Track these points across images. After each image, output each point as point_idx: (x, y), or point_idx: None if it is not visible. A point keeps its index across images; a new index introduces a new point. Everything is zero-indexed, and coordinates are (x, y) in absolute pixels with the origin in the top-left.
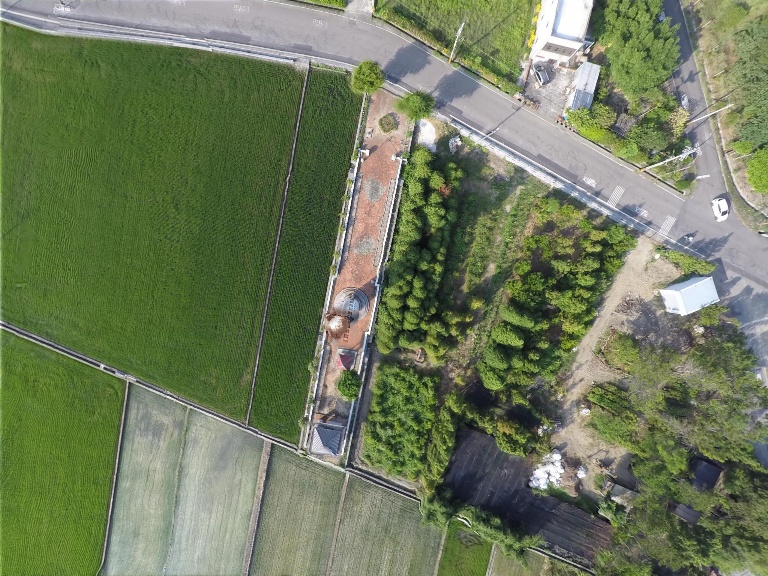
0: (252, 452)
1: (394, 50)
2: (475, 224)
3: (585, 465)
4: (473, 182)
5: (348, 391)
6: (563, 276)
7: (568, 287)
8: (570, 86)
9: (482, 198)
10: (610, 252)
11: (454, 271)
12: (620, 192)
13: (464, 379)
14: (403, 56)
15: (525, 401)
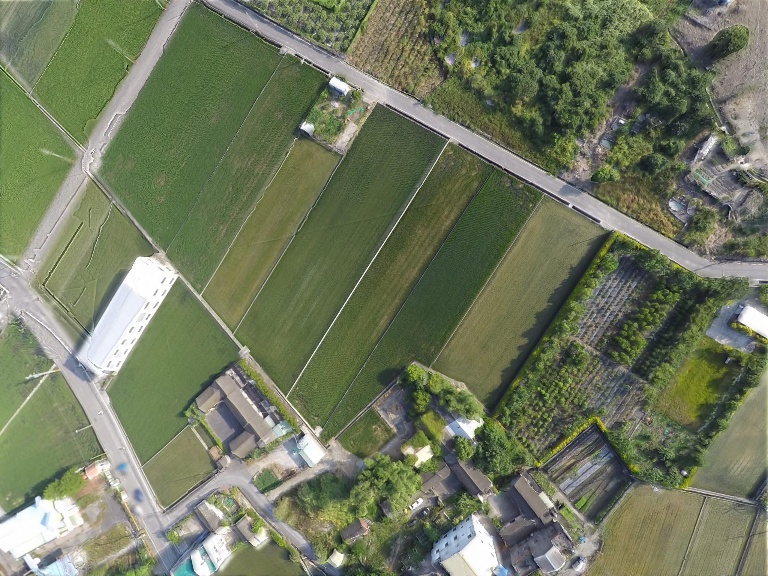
0: None
1: None
2: None
3: None
4: None
5: None
6: None
7: None
8: None
9: None
10: None
11: None
12: None
13: None
14: None
15: None
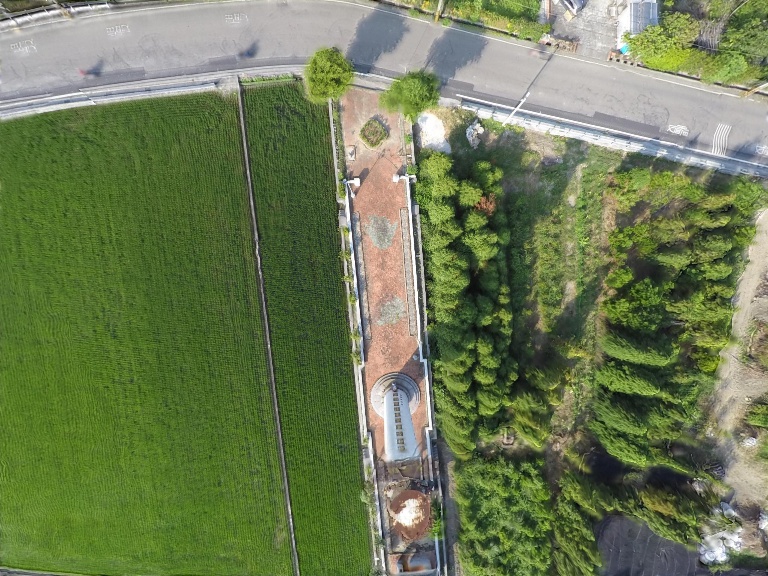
0: None
1: (352, 26)
2: (532, 236)
3: (765, 510)
4: (513, 179)
5: (430, 528)
6: (681, 274)
7: (693, 287)
8: (614, 3)
9: (532, 197)
10: (739, 221)
11: (522, 309)
12: (724, 132)
13: (575, 448)
14: (367, 30)
15: (681, 466)
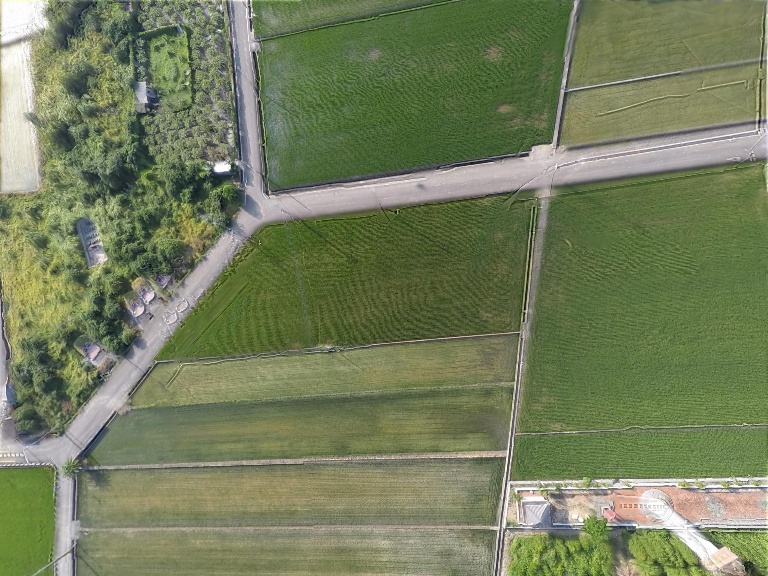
0: (496, 443)
1: None
2: None
3: None
4: None
5: (596, 530)
6: None
7: None
8: None
9: None
10: None
11: None
12: None
13: None
14: None
15: None
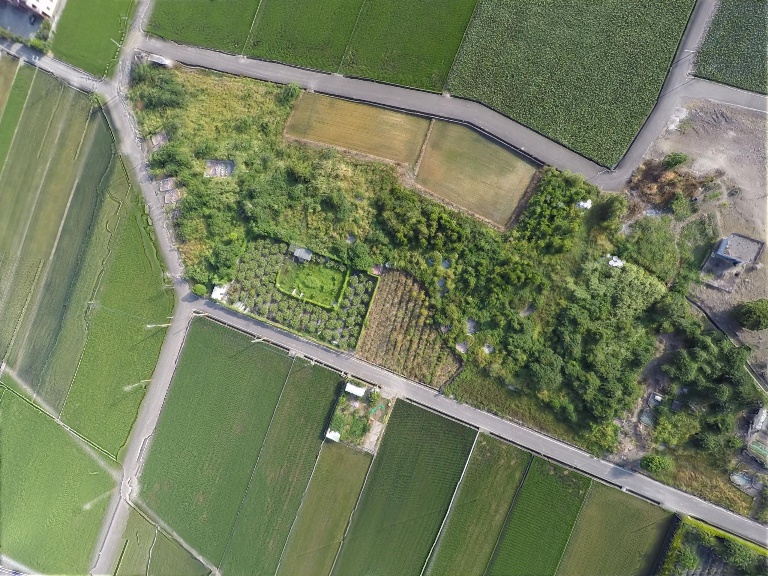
0: (5, 377)
1: None
2: None
3: None
4: None
5: None
6: None
7: None
8: None
9: None
10: None
11: None
12: None
13: None
14: None
15: None
